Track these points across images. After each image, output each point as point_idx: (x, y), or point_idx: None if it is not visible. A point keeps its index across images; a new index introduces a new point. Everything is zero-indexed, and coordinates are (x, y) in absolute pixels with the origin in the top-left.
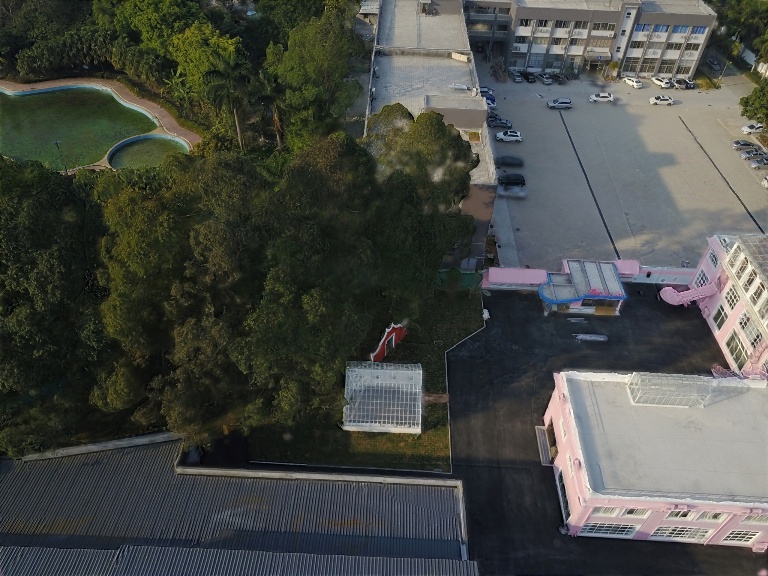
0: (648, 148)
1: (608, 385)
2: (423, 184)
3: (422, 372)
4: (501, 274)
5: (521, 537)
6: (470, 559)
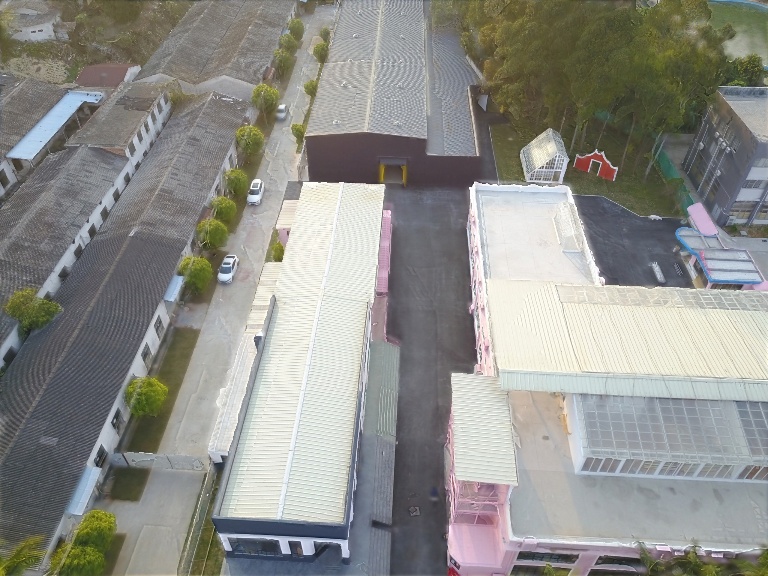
0: None
1: None
2: (639, 33)
3: (579, 186)
4: (698, 211)
5: (462, 208)
6: (447, 189)
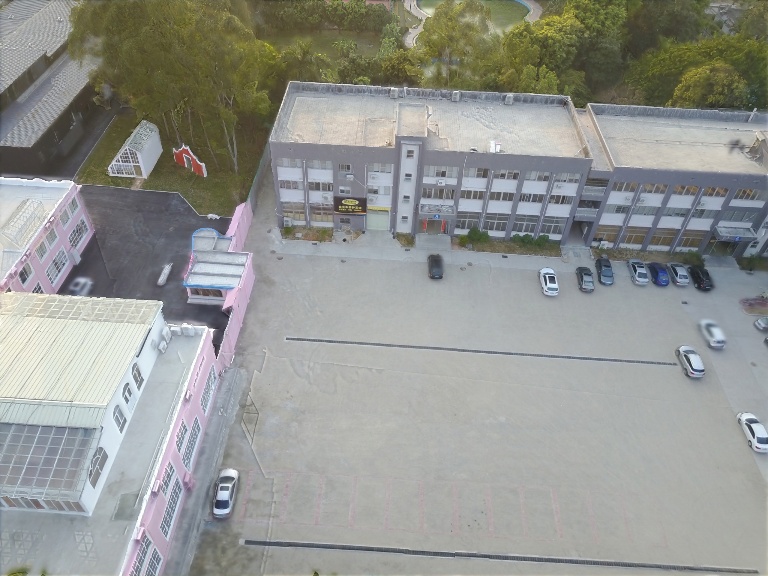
0: (581, 457)
1: (54, 207)
2: None
3: (164, 182)
4: None
5: None
6: None
